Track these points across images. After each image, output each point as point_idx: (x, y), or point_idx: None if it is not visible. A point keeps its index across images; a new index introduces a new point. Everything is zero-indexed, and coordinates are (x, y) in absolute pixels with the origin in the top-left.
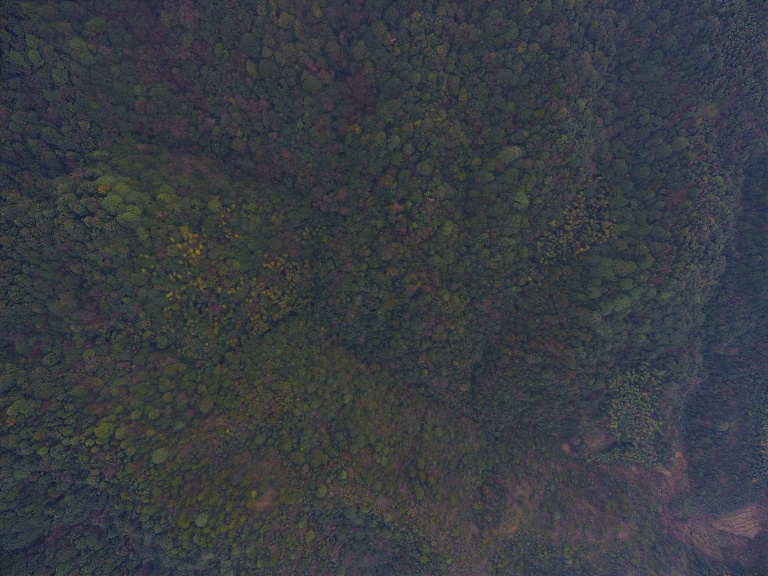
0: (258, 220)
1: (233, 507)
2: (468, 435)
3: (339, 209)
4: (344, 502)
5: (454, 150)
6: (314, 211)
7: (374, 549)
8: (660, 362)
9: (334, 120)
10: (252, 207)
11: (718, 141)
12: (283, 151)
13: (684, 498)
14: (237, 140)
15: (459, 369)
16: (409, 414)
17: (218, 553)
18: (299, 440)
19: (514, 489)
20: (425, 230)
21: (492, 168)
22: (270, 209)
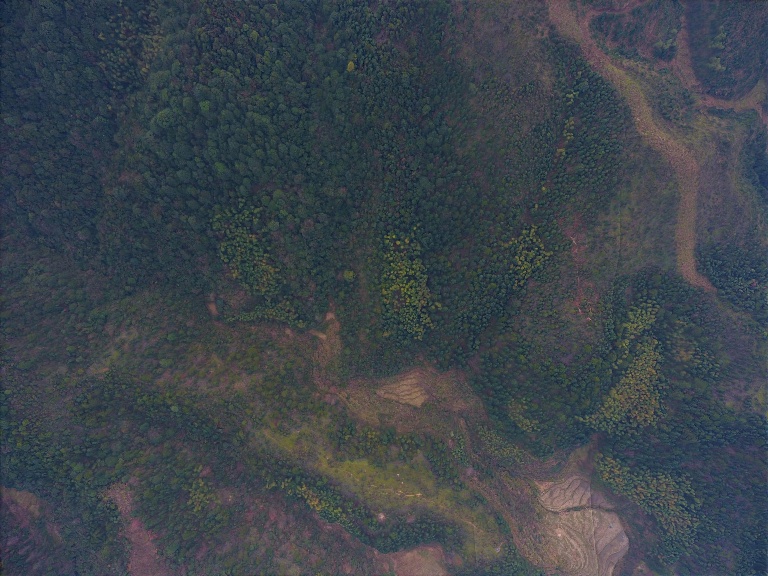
0: None
1: None
2: (85, 284)
3: None
4: None
5: None
6: None
7: None
8: None
9: None
10: None
11: None
12: None
13: (335, 360)
14: None
15: (66, 212)
16: (13, 258)
17: None
18: None
19: (116, 333)
20: None
21: None
22: None
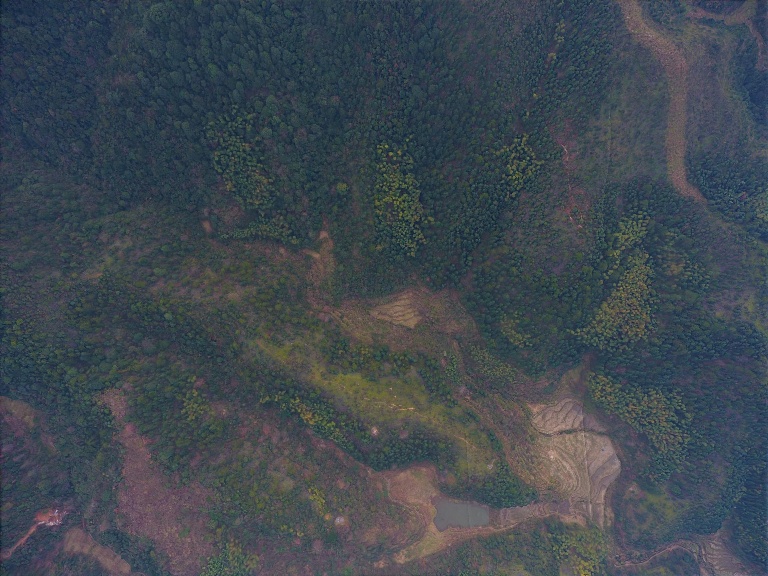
0: None
1: None
2: (79, 196)
3: None
4: None
5: None
6: None
7: None
8: None
9: None
10: None
11: None
12: None
13: (328, 278)
14: None
15: (61, 122)
16: (8, 167)
17: None
18: None
19: (110, 241)
20: None
21: None
22: None
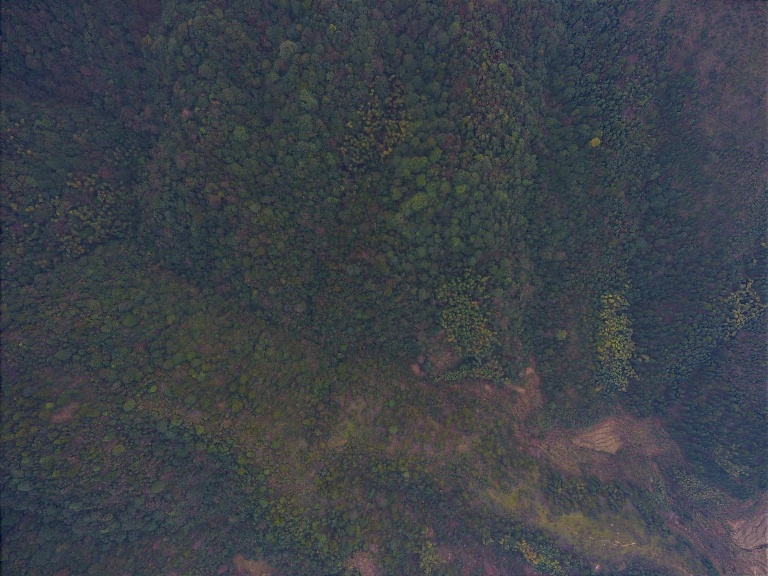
0: (54, 137)
1: (22, 417)
2: (305, 355)
3: (149, 128)
4: (153, 415)
5: (239, 52)
6: (127, 132)
7: (200, 467)
8: (482, 267)
9: (127, 33)
10: (46, 123)
11: (505, 31)
12: (83, 69)
13: (537, 414)
14: (28, 56)
15: (289, 288)
16: (240, 335)
17: (7, 463)
18: (111, 358)
19: (347, 404)
20: (215, 135)
21: (276, 68)
22: (70, 127)
